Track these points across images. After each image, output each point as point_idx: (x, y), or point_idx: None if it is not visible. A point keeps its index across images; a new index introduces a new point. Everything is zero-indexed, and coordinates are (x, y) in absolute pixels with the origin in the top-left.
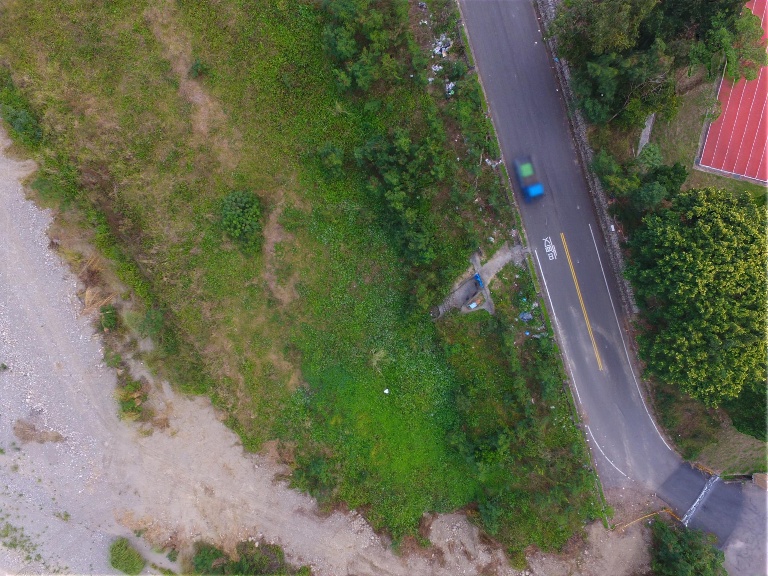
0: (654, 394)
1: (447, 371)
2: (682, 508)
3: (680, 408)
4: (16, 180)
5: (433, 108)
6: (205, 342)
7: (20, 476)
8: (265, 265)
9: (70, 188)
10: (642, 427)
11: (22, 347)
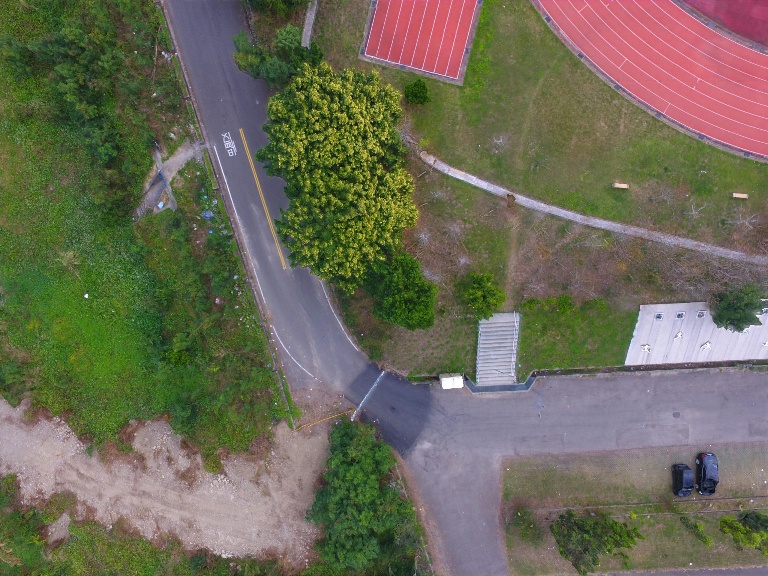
0: (338, 293)
1: (145, 275)
2: (370, 409)
3: (357, 306)
4: None
5: None
6: None
7: None
8: None
9: None
10: (328, 327)
11: None
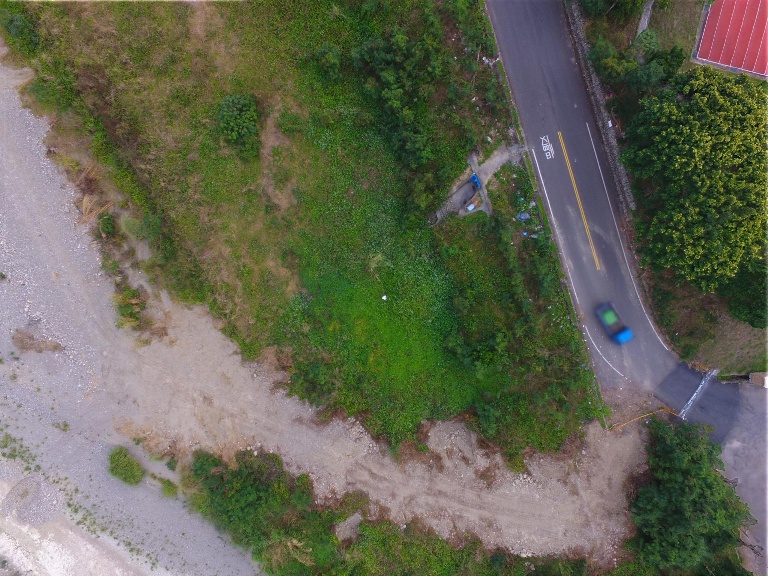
0: (651, 293)
1: (445, 276)
2: (679, 408)
3: (677, 305)
4: (13, 88)
5: (430, 3)
6: (203, 247)
7: (19, 386)
8: (263, 171)
9: (67, 95)
10: (639, 327)
11: (20, 256)
